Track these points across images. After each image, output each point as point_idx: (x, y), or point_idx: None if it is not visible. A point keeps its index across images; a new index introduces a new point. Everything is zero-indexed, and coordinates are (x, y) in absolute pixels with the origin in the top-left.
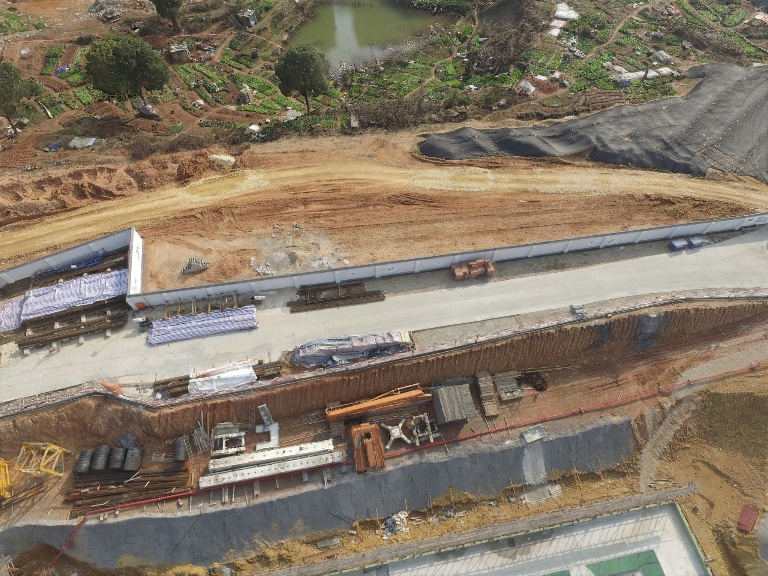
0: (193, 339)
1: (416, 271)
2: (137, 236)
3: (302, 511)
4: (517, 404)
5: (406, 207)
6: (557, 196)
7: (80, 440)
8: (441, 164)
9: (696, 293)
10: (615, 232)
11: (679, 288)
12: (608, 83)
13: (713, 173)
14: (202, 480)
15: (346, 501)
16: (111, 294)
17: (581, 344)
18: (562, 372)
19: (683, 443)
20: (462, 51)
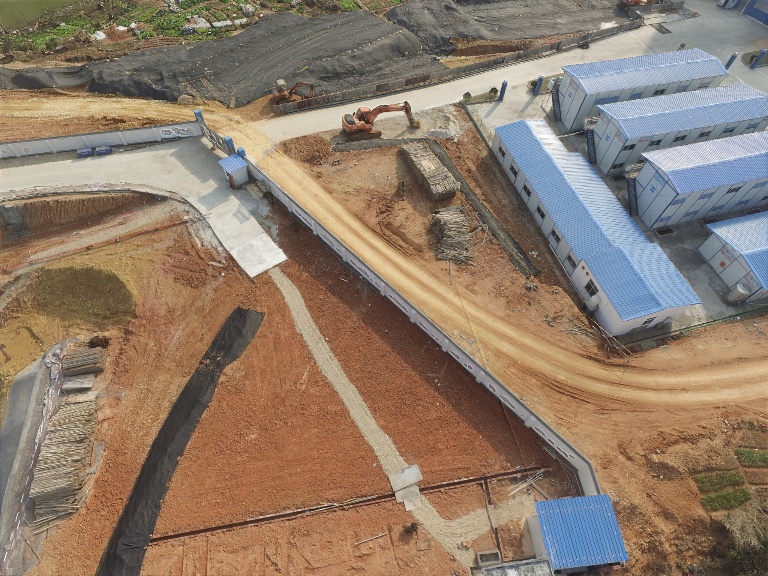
0: None
1: None
2: None
3: None
4: None
5: None
6: (27, 119)
7: None
8: None
9: (52, 186)
10: None
11: None
12: (175, 31)
13: (184, 98)
14: None
15: None
16: None
17: None
18: None
19: (16, 313)
20: None
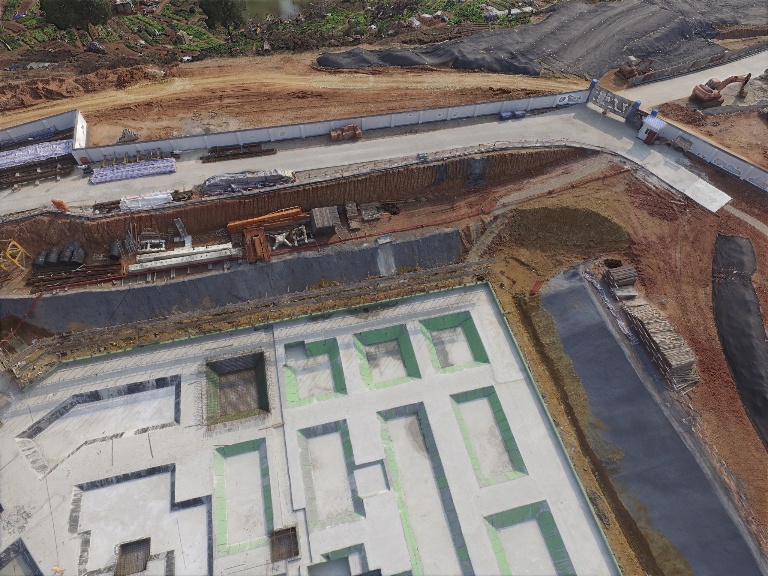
0: (125, 180)
1: (303, 136)
2: (82, 118)
3: (208, 291)
4: (376, 223)
5: (301, 99)
6: (422, 91)
7: (37, 248)
8: (334, 72)
9: (509, 141)
10: (455, 105)
11: (501, 142)
12: (479, 18)
13: (545, 73)
14: (131, 266)
15: (242, 285)
16: (60, 153)
17: (425, 181)
18: (412, 203)
19: (499, 247)
20: (373, 6)
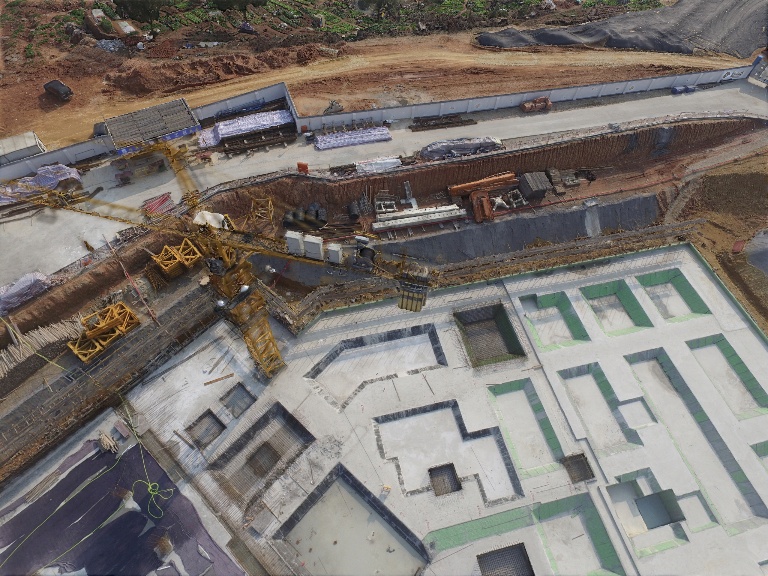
0: (348, 146)
1: (495, 108)
2: None
3: (441, 248)
4: (577, 188)
5: (477, 75)
6: (586, 67)
7: (280, 208)
8: (496, 50)
9: (694, 112)
10: (634, 79)
11: (682, 113)
12: (612, 1)
13: (698, 51)
14: (374, 224)
15: (469, 243)
16: (281, 122)
17: (618, 149)
18: (605, 170)
19: (692, 210)
20: None
